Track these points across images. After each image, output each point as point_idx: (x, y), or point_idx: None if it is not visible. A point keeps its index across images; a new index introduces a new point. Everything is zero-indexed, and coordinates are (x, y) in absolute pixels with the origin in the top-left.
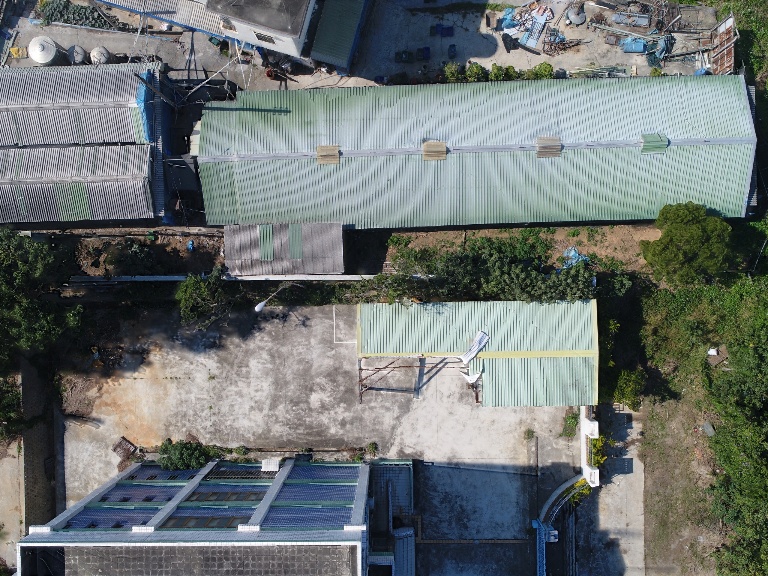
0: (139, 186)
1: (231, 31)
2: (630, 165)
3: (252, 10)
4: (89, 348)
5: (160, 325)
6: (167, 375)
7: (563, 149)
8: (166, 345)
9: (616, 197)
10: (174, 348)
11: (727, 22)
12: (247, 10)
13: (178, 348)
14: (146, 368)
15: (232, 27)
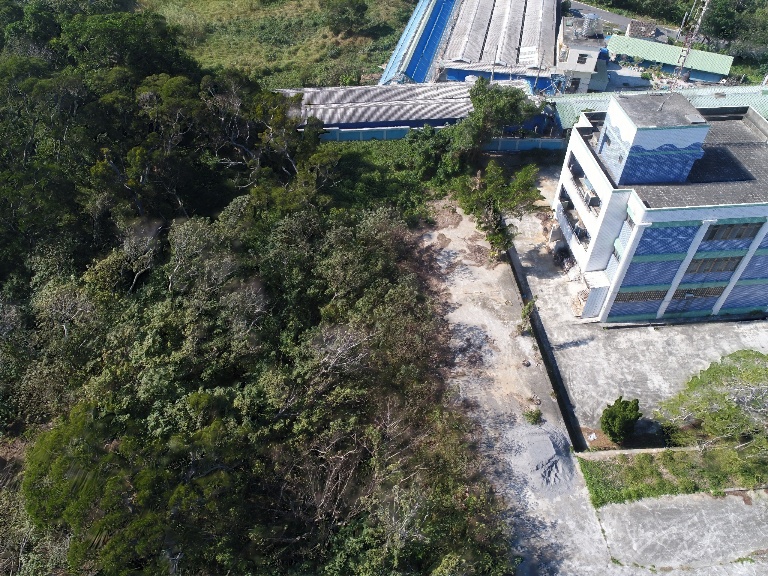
0: (536, 102)
1: (564, 62)
2: (760, 100)
3: (582, 42)
4: (509, 176)
5: (544, 171)
6: (556, 188)
7: (726, 95)
8: (551, 177)
9: (761, 111)
10: (556, 178)
11: (765, 79)
12: (580, 42)
13: (558, 178)
14: (543, 186)
15: (564, 60)
